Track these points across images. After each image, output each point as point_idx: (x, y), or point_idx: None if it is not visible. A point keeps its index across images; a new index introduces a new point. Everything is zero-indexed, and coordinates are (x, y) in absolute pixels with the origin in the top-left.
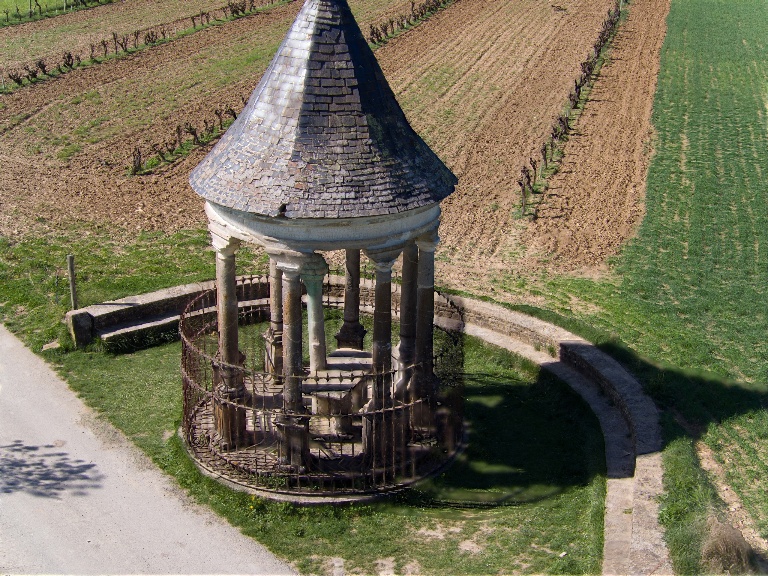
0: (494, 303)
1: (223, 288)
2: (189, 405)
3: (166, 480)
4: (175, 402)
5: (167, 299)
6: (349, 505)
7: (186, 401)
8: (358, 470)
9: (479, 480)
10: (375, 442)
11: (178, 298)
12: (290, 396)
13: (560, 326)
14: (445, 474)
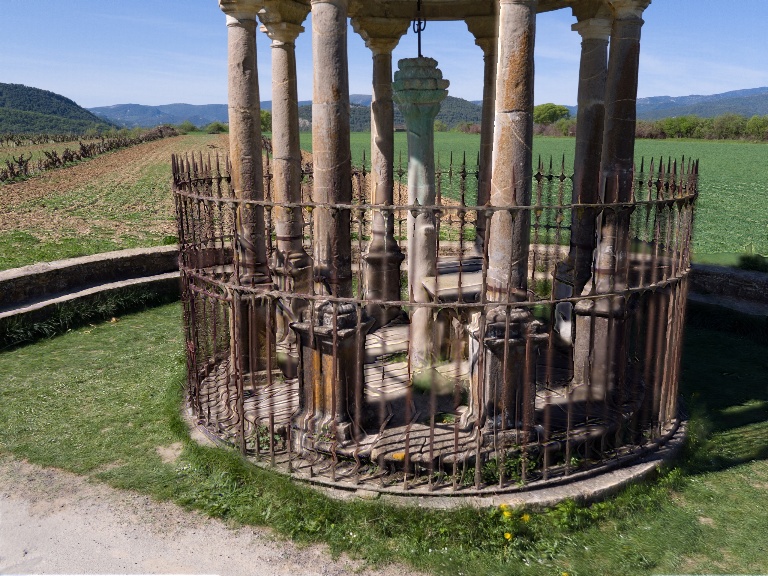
0: (451, 240)
1: (331, 70)
2: (175, 397)
3: (249, 540)
4: (135, 402)
5: (29, 276)
6: (654, 475)
7: (240, 355)
8: (610, 411)
9: (712, 396)
10: (620, 355)
11: (46, 275)
12: (517, 276)
13: (551, 243)
14: (683, 395)
